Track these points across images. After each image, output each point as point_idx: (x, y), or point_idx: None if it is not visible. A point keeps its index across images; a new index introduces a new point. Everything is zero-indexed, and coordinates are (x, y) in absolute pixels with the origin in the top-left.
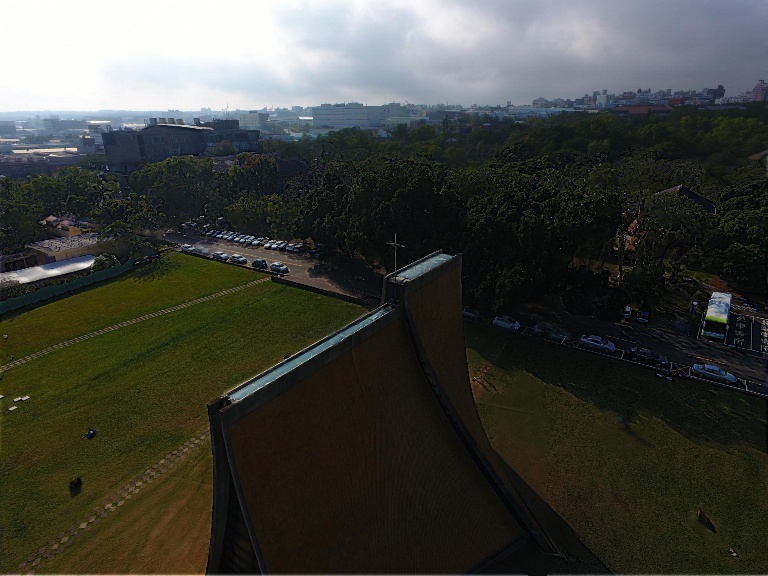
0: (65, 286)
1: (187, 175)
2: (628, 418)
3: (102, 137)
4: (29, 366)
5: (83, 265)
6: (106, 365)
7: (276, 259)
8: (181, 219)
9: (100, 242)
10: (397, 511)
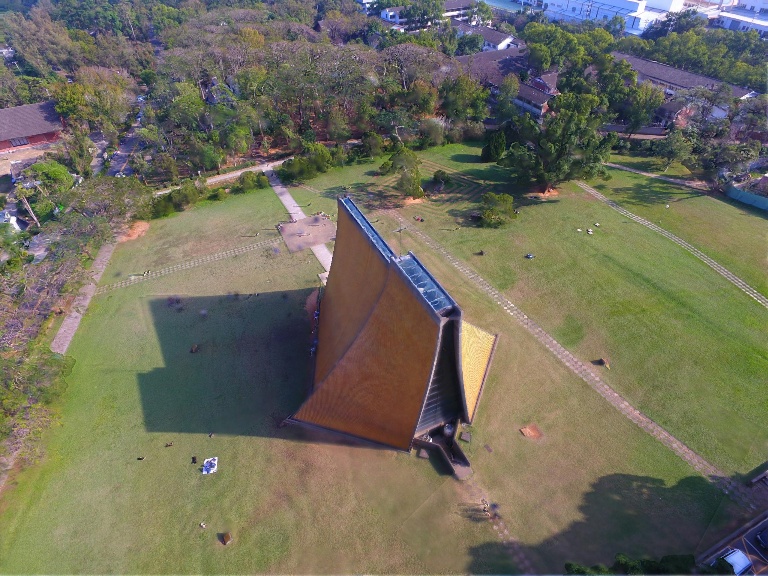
0: None
1: None
2: None
3: None
4: (641, 230)
5: None
6: (627, 260)
7: None
8: None
9: None
10: None
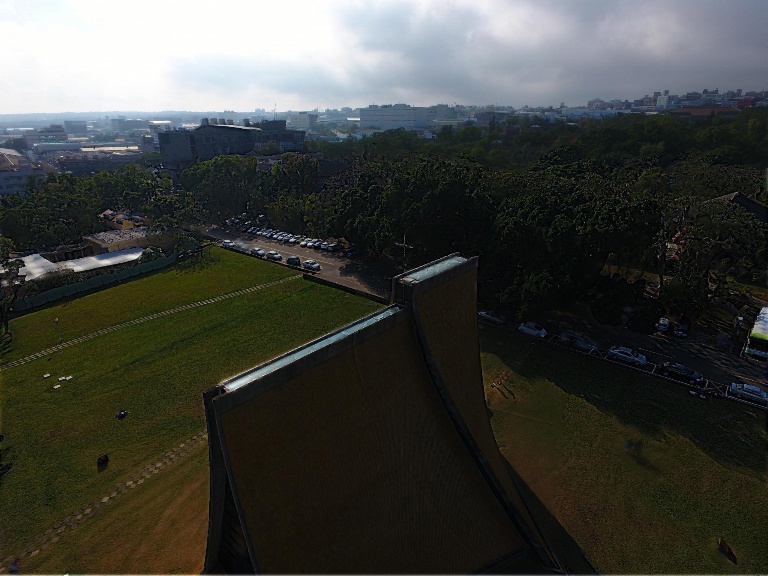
0: (114, 276)
1: (232, 173)
2: (652, 435)
3: (158, 136)
4: (75, 348)
5: (132, 257)
6: (142, 351)
7: (310, 257)
8: (225, 216)
9: (148, 235)
10: (392, 511)
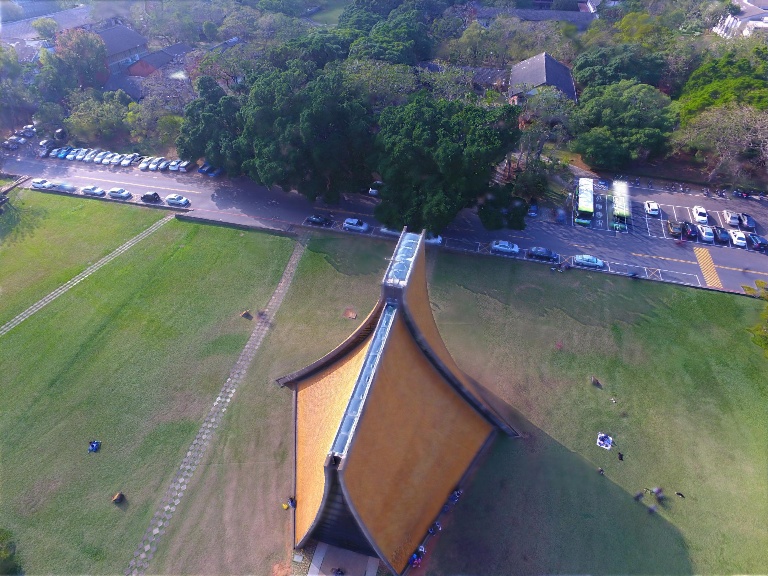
0: None
1: None
2: (538, 313)
3: None
4: None
5: None
6: (51, 367)
7: (165, 186)
8: None
9: None
10: (424, 453)
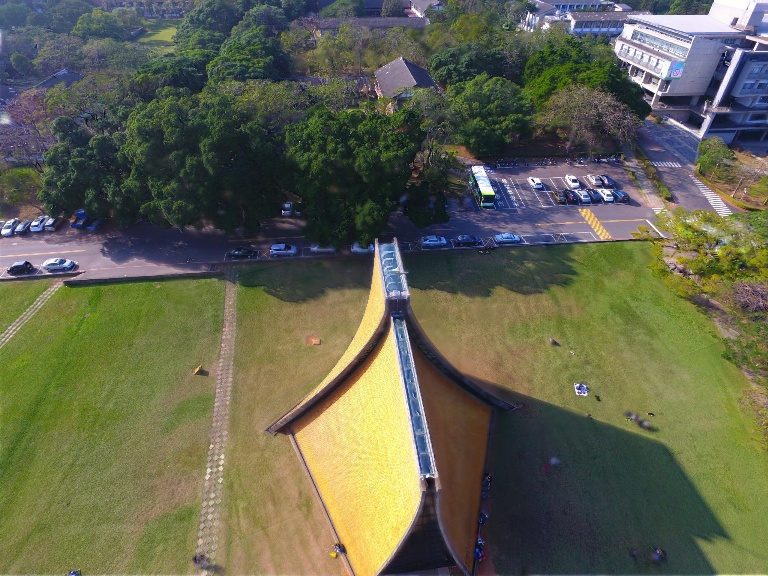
0: None
1: None
2: (484, 294)
3: None
4: None
5: None
6: None
7: (33, 251)
8: None
9: None
10: (456, 450)
